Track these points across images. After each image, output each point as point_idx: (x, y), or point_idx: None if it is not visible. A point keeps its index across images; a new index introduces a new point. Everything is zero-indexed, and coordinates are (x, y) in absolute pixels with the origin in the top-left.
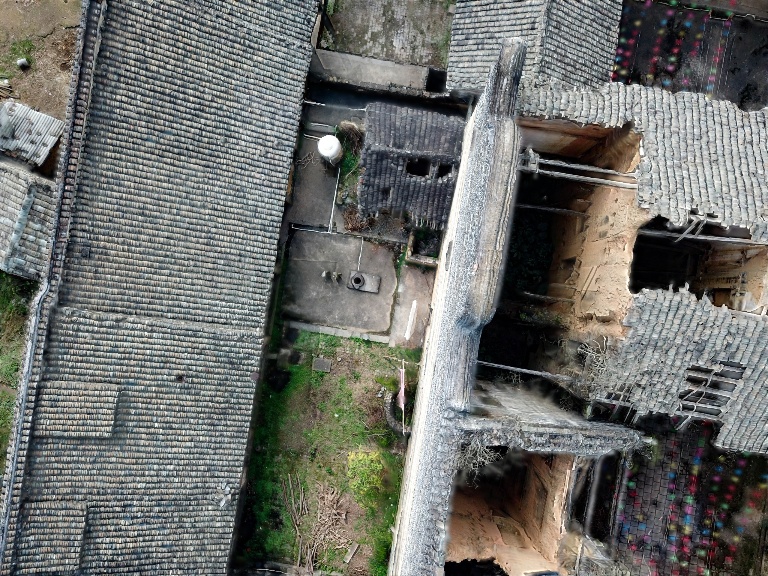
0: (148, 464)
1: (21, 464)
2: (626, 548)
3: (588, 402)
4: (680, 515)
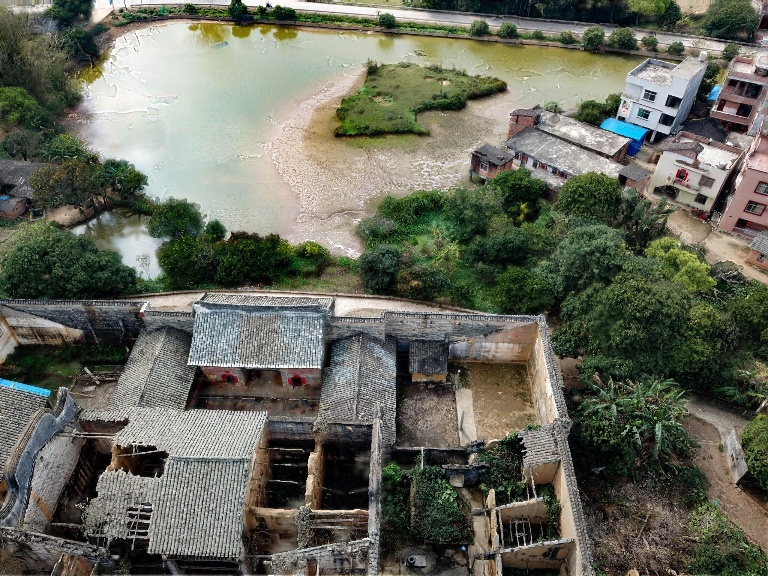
0: None
1: None
2: None
3: (86, 538)
4: None
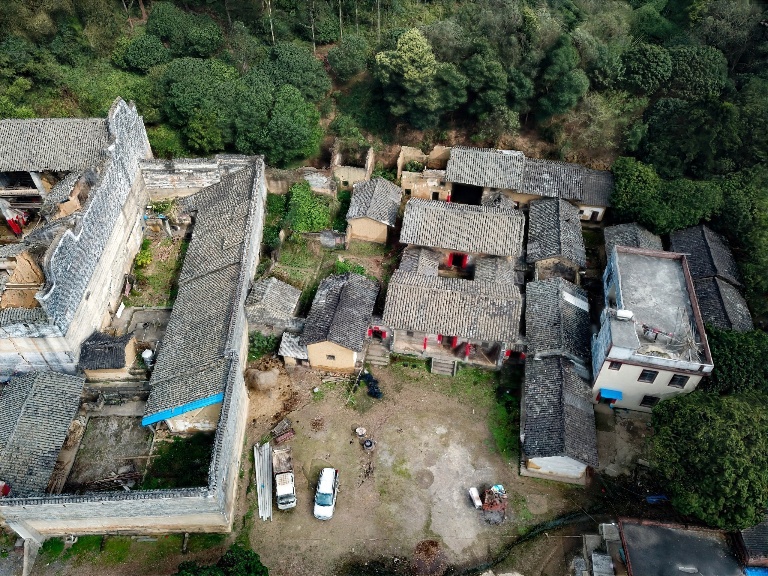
0: None
1: None
2: None
3: None
4: None
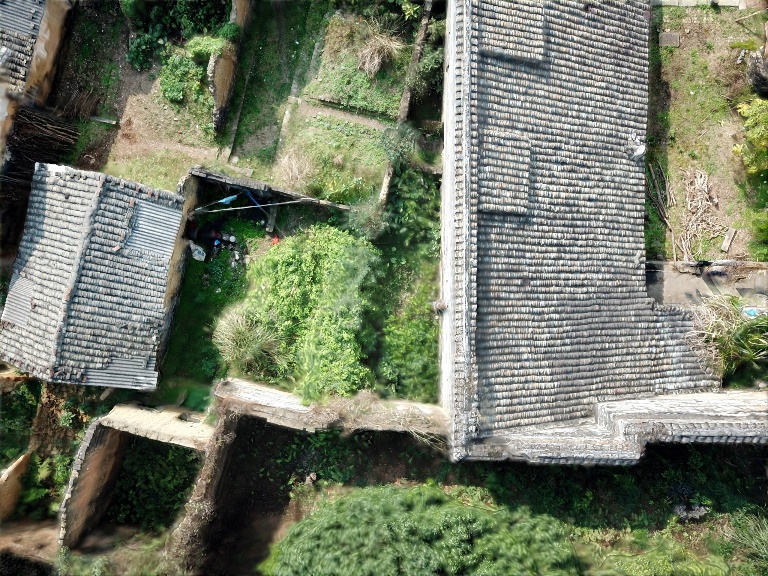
0: (569, 103)
1: (474, 78)
2: None
3: None
4: None
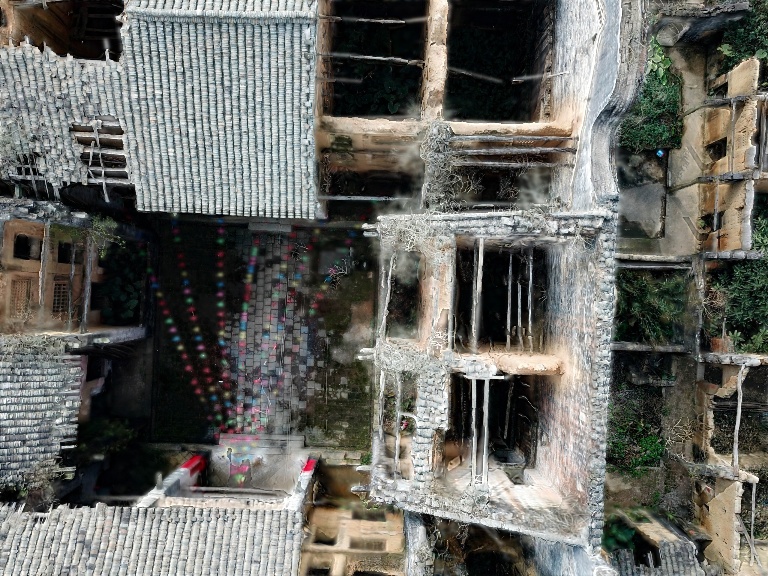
0: None
1: None
2: (244, 381)
3: (9, 182)
4: (293, 342)
